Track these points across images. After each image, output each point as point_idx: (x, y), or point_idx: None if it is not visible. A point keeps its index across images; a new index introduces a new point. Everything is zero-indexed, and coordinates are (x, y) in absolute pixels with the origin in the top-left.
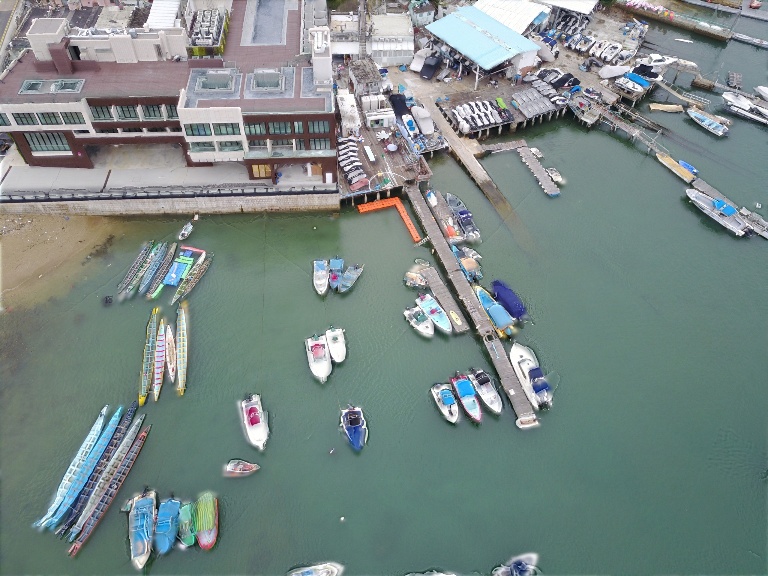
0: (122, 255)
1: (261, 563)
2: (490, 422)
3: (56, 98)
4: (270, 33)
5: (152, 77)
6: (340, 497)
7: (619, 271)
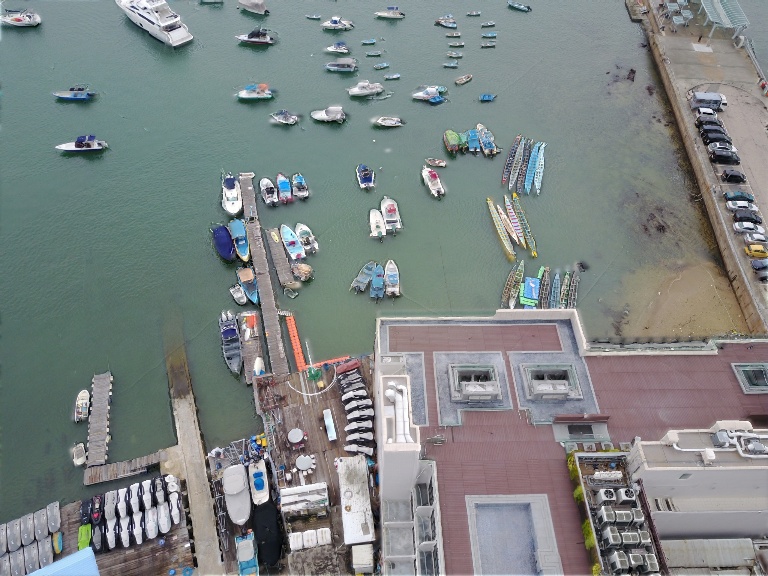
0: (595, 314)
1: (418, 132)
2: (273, 173)
3: (756, 358)
4: (506, 569)
5: (652, 401)
6: (375, 154)
7: (95, 287)
